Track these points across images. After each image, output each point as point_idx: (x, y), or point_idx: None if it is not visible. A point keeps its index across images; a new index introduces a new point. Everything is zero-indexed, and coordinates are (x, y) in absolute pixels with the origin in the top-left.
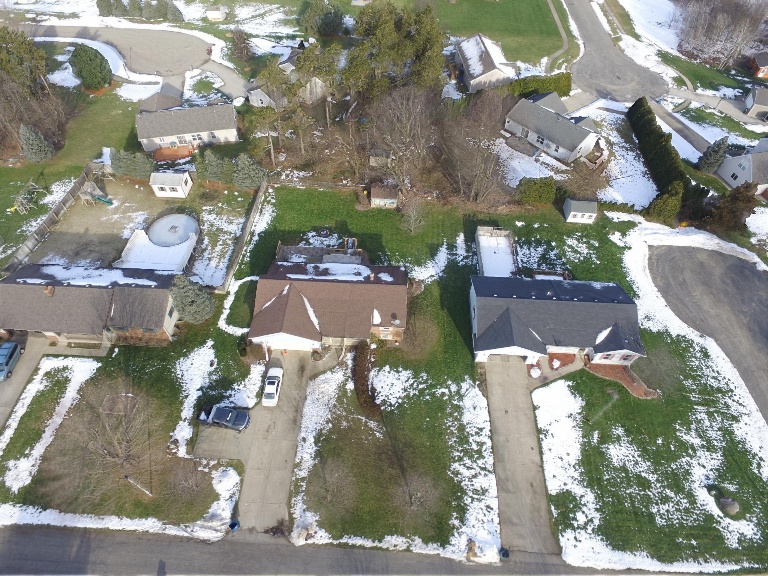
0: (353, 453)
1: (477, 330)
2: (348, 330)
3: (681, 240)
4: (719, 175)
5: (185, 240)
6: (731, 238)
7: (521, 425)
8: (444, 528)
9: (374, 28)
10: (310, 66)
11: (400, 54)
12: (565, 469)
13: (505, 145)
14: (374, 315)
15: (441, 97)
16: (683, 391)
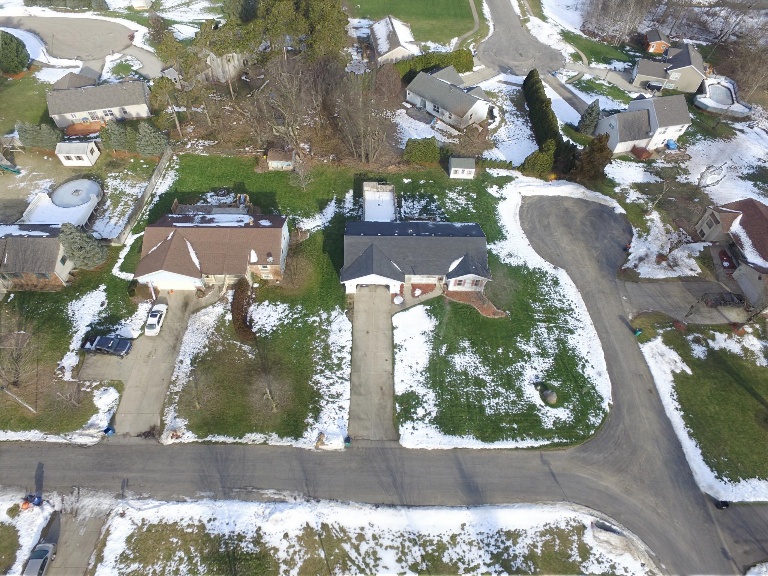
0: (225, 371)
1: (344, 264)
2: (226, 268)
3: (551, 190)
4: (596, 136)
5: (87, 201)
6: (597, 188)
7: (379, 342)
8: (299, 425)
9: (272, 6)
10: (206, 40)
11: (295, 29)
12: (413, 375)
13: (405, 115)
14: (251, 255)
15: (342, 71)
16: (529, 311)
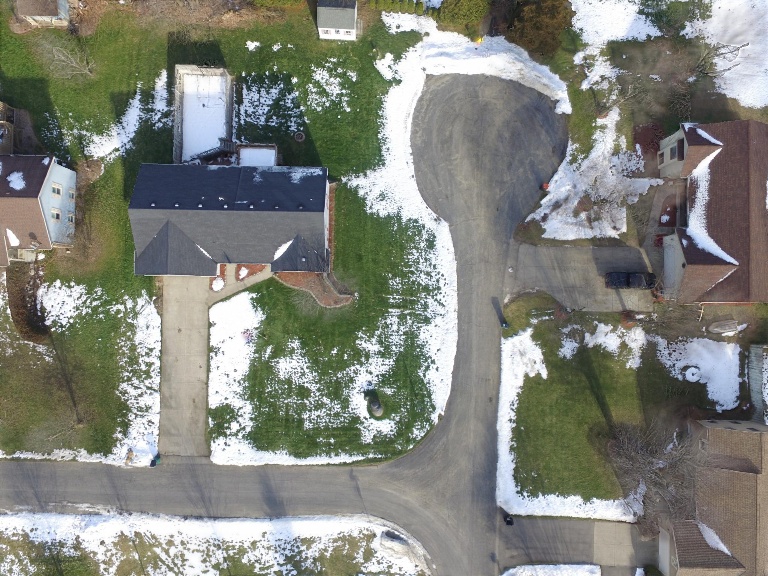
0: (21, 379)
1: (136, 249)
2: None
3: (473, 65)
4: None
5: None
6: (548, 55)
7: (193, 344)
8: (108, 441)
9: None
10: None
11: None
12: (229, 385)
13: None
14: (8, 236)
15: None
16: (384, 293)
